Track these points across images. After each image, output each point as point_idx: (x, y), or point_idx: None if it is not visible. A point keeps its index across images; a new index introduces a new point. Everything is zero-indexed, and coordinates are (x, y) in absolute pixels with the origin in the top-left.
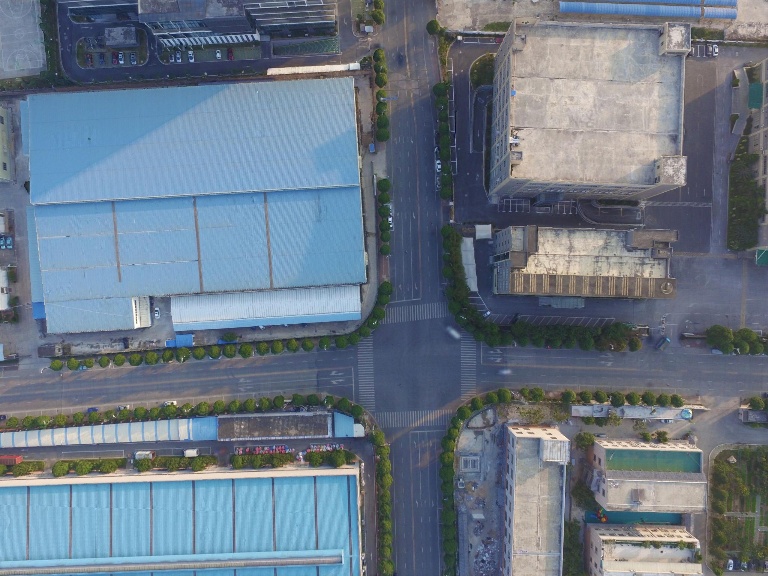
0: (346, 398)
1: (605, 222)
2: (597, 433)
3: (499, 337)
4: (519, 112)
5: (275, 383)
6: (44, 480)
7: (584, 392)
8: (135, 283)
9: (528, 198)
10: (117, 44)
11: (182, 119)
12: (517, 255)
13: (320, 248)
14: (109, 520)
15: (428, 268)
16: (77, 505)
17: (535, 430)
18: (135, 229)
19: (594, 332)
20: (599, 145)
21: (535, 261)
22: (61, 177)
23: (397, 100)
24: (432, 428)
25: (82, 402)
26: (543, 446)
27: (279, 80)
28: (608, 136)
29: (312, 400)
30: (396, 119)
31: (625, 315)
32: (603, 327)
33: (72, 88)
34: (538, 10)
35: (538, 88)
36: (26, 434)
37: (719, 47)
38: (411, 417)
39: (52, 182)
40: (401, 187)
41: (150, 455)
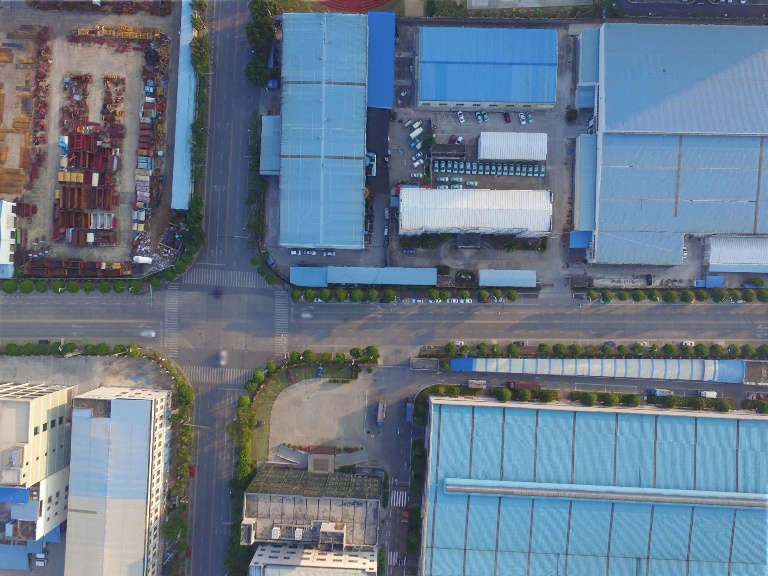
0: None
1: None
2: None
3: None
4: None
5: None
6: (582, 407)
7: None
8: (690, 219)
9: None
10: None
11: (757, 58)
12: None
13: None
14: (653, 451)
15: None
16: (622, 434)
17: None
18: (699, 165)
19: None
20: None
21: None
22: (635, 106)
23: None
24: None
25: (599, 335)
26: None
27: None
28: None
29: None
30: None
31: None
32: None
33: (623, 20)
34: None
35: None
36: (550, 362)
37: None
38: None
39: (626, 111)
40: None
41: (672, 393)
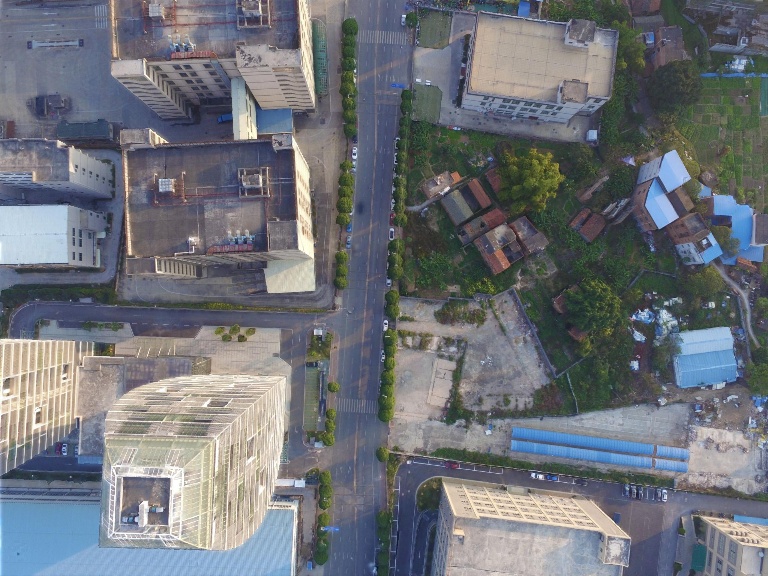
0: None
1: None
2: None
3: None
4: None
5: None
6: None
7: None
8: None
9: None
10: (61, 441)
11: None
12: None
13: None
14: None
15: None
16: None
17: None
18: None
19: None
20: None
21: None
22: None
23: (341, 515)
24: None
25: None
26: None
27: None
28: None
29: None
30: (338, 534)
31: None
32: None
33: None
34: (490, 441)
35: None
36: None
37: (668, 492)
38: None
39: None
40: None
41: None
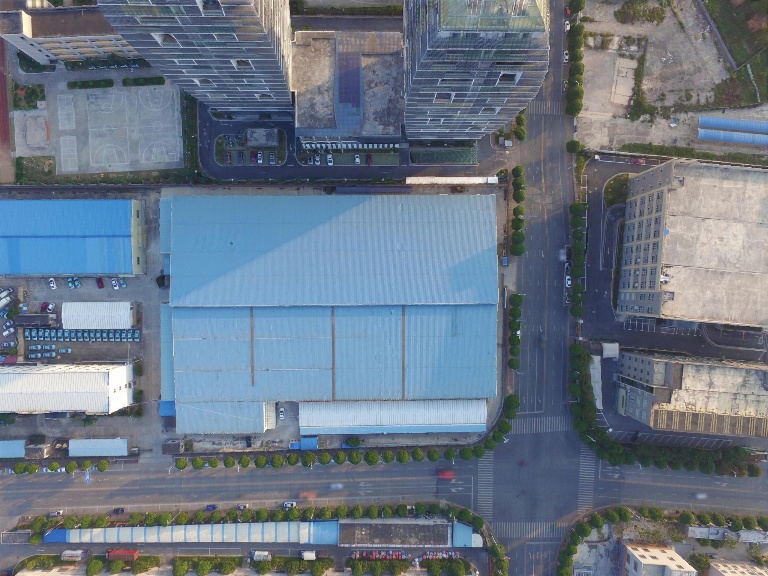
0: (465, 507)
1: (727, 344)
2: (709, 553)
3: (623, 458)
4: (670, 250)
5: (395, 488)
6: None
7: (703, 515)
8: (268, 388)
9: (654, 318)
10: (259, 145)
11: (325, 228)
12: (661, 392)
13: (454, 362)
14: None
15: (552, 381)
16: None
17: (655, 552)
18: (272, 335)
19: (716, 457)
20: (745, 286)
21: (675, 395)
22: (202, 280)
23: (531, 214)
24: (547, 540)
25: (201, 498)
26: (671, 575)
27: (415, 187)
28: (755, 278)
29: (436, 511)
30: (529, 232)
31: (742, 437)
32: (721, 449)
33: (210, 185)
34: (675, 134)
35: (689, 227)
36: (145, 530)
37: None
38: (527, 528)
39: (192, 285)
40: (530, 300)
41: (269, 557)
